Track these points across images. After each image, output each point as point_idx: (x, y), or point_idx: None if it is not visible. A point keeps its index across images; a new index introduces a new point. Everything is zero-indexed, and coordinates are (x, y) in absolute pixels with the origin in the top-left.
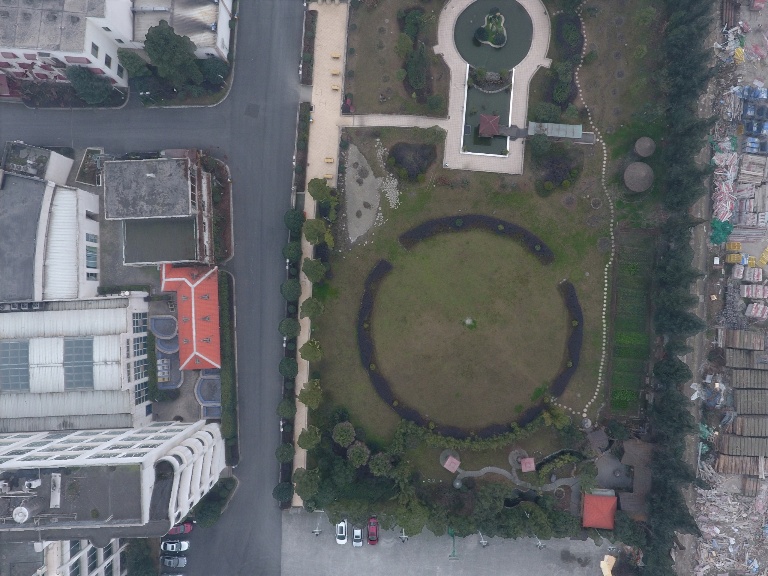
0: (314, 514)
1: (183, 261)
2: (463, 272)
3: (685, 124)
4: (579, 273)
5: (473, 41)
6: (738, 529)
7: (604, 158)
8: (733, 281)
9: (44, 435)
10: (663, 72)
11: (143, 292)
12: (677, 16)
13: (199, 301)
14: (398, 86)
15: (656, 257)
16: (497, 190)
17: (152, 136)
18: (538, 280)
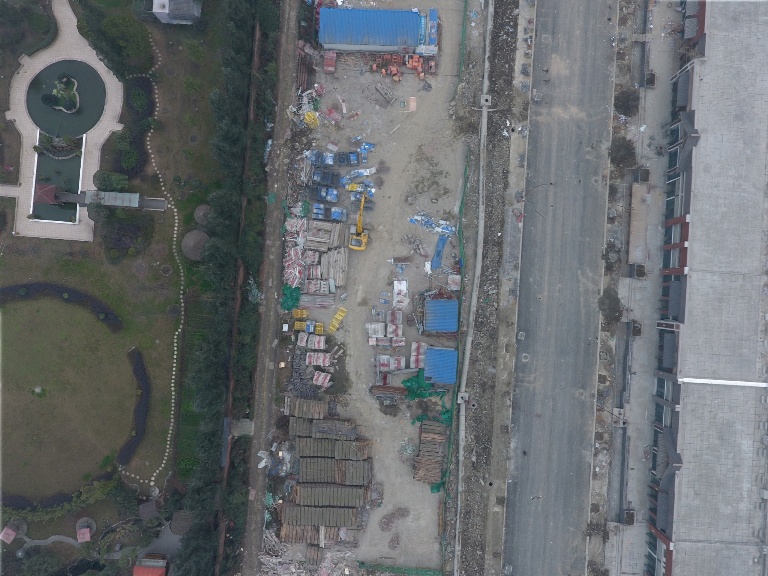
0: None
1: None
2: (33, 340)
3: None
4: (149, 341)
5: None
6: None
7: (175, 224)
8: (302, 348)
9: None
10: (214, 140)
11: None
12: None
13: None
14: None
15: None
16: (68, 257)
17: None
18: (108, 348)
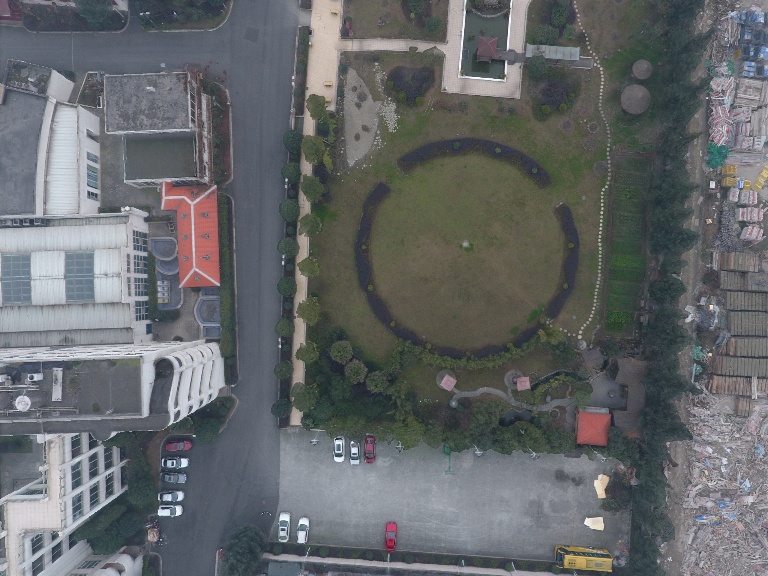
0: (312, 433)
1: (183, 178)
2: (460, 195)
3: (682, 42)
4: (575, 197)
5: None
6: (731, 449)
7: (601, 83)
8: (728, 205)
9: (46, 349)
10: None
11: (143, 211)
12: None
13: (199, 218)
14: (397, 10)
15: (652, 181)
16: (495, 114)
17: (152, 60)
18: (535, 204)
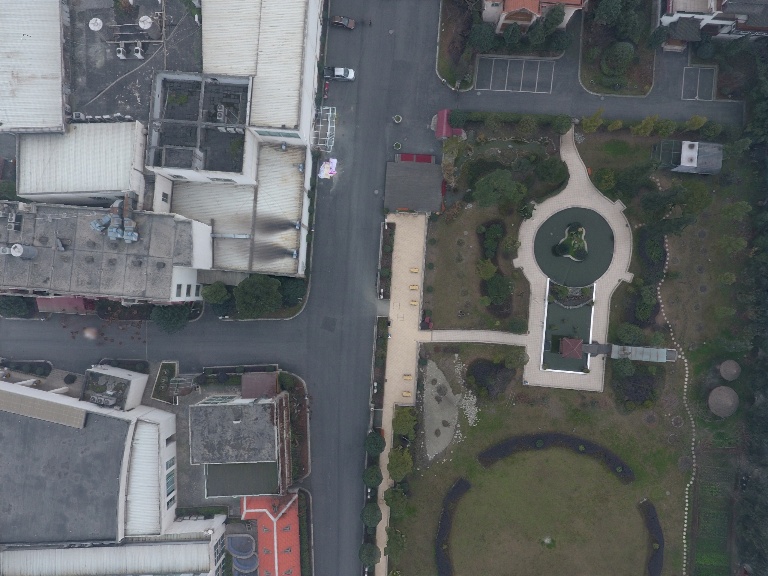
0: None
1: None
2: (542, 491)
3: None
4: (660, 492)
5: (552, 251)
6: None
7: (686, 375)
8: None
9: None
10: (751, 299)
11: (222, 518)
12: (766, 242)
13: (281, 534)
14: (477, 300)
15: (738, 476)
16: (577, 407)
17: (227, 349)
18: (618, 499)
